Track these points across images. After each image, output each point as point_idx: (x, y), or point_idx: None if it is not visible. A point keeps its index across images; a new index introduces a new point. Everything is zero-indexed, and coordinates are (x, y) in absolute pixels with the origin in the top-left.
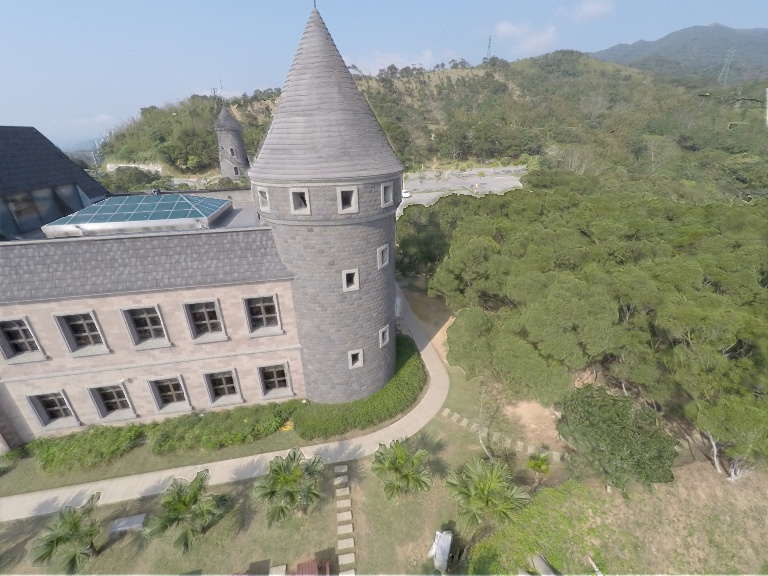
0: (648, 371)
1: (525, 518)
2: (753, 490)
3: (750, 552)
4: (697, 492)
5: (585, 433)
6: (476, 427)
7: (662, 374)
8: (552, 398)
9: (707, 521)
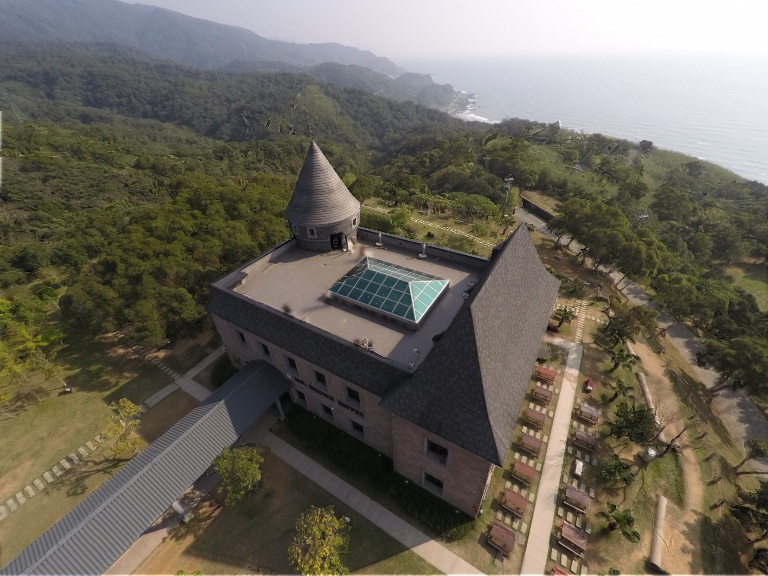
0: None
1: None
2: None
3: None
4: None
5: None
6: None
7: None
8: None
9: None
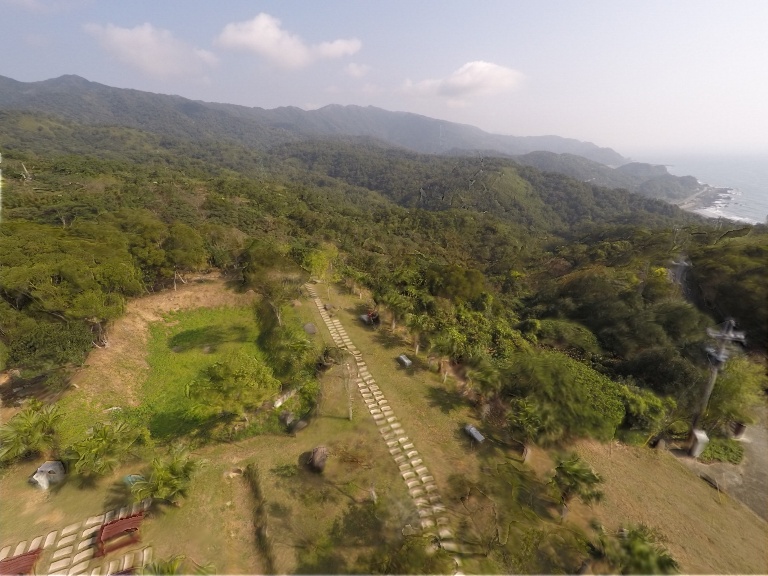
0: (27, 322)
1: (63, 427)
2: (116, 344)
3: (138, 361)
4: (103, 359)
5: (43, 354)
6: None
7: (35, 318)
8: (2, 360)
9: (118, 364)
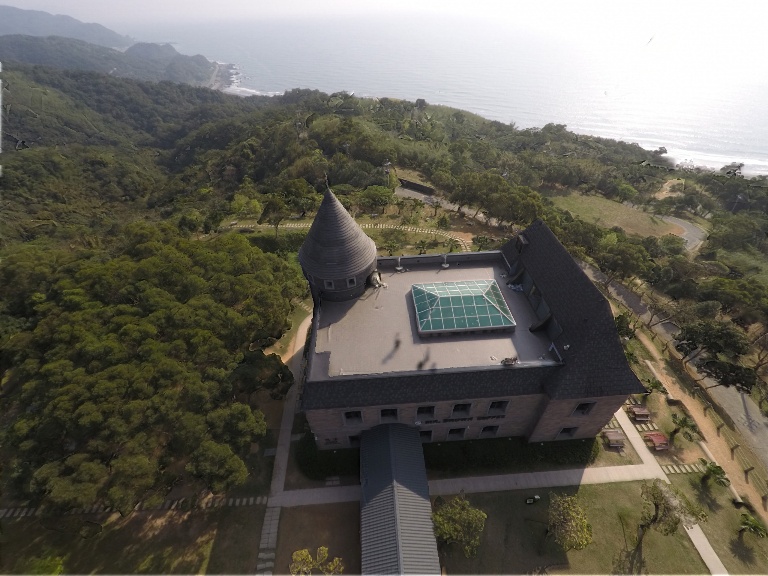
0: None
1: None
2: None
3: None
4: None
5: None
6: (303, 305)
7: None
8: None
9: None
